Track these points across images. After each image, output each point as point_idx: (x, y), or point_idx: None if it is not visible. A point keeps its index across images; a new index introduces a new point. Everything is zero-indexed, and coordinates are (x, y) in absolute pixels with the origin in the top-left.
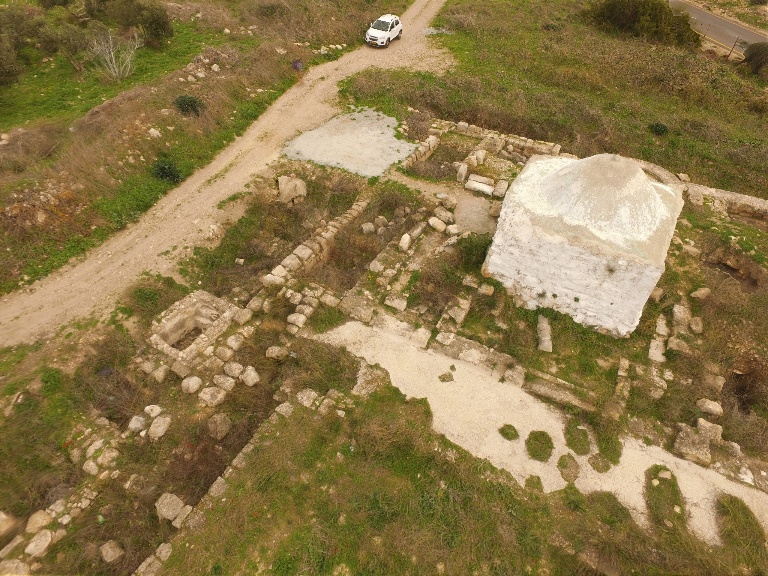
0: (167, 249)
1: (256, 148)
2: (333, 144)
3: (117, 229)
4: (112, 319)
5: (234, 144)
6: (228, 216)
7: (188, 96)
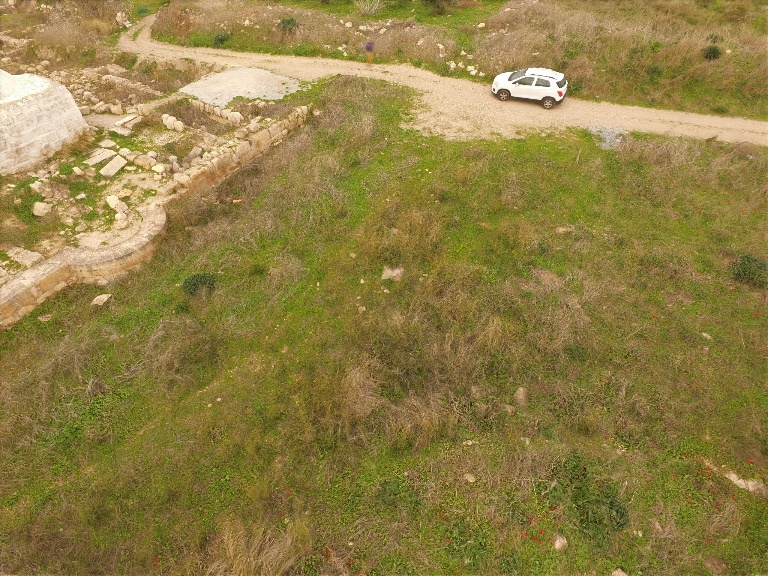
0: (154, 54)
1: (252, 60)
2: (239, 78)
3: (182, 44)
4: (113, 53)
5: (260, 54)
6: (178, 64)
7: (294, 21)
